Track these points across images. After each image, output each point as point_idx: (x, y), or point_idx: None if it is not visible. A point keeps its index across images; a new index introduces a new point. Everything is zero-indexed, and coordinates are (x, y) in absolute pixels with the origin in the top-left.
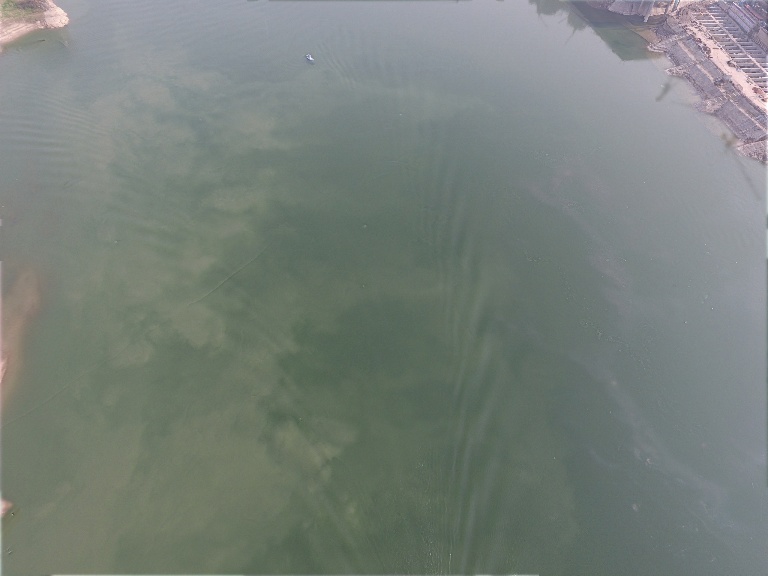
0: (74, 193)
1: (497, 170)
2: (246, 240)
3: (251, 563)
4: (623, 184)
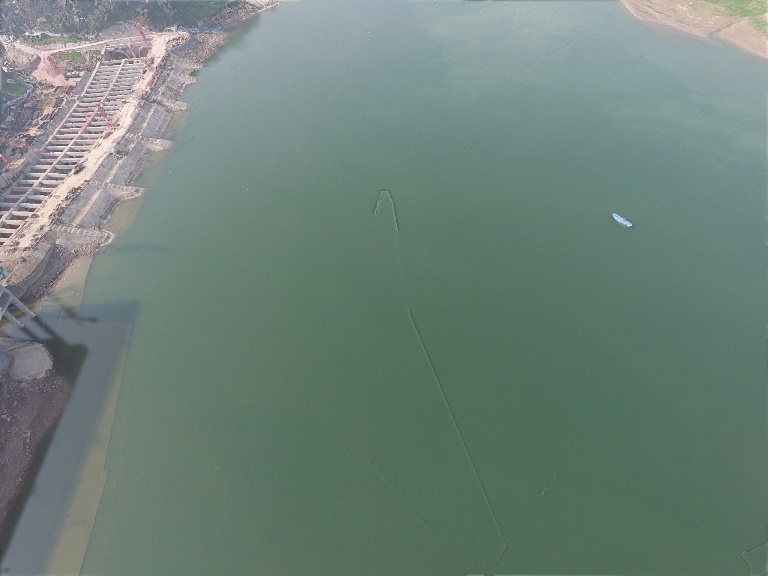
0: (718, 79)
1: (391, 84)
2: (561, 58)
3: None
4: (301, 85)
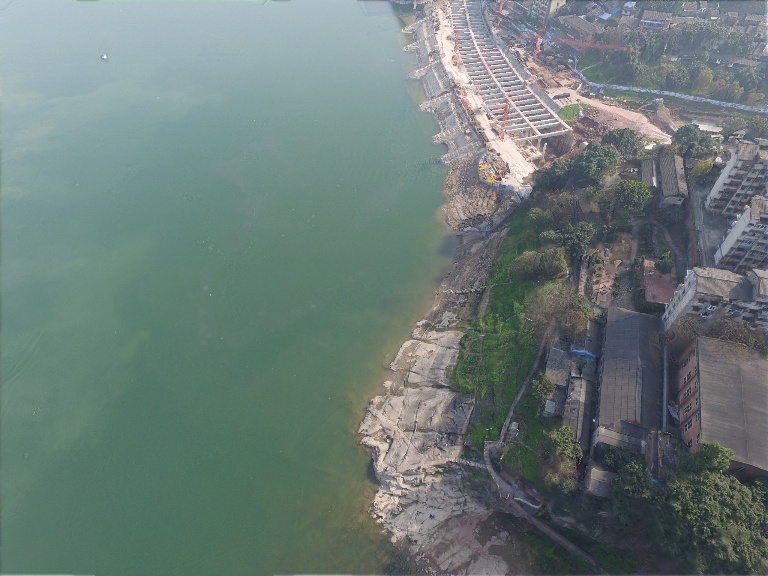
0: None
1: (202, 134)
2: None
3: None
4: (305, 139)
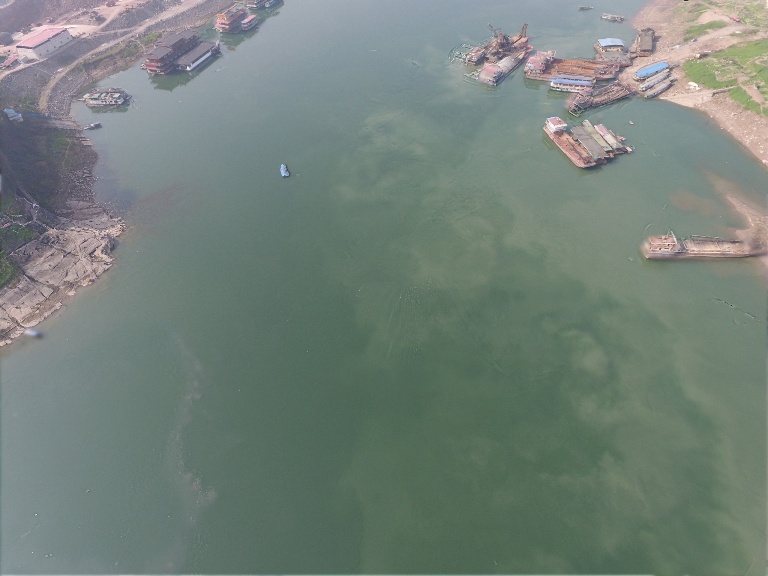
0: None
1: None
2: None
3: (534, 291)
4: None
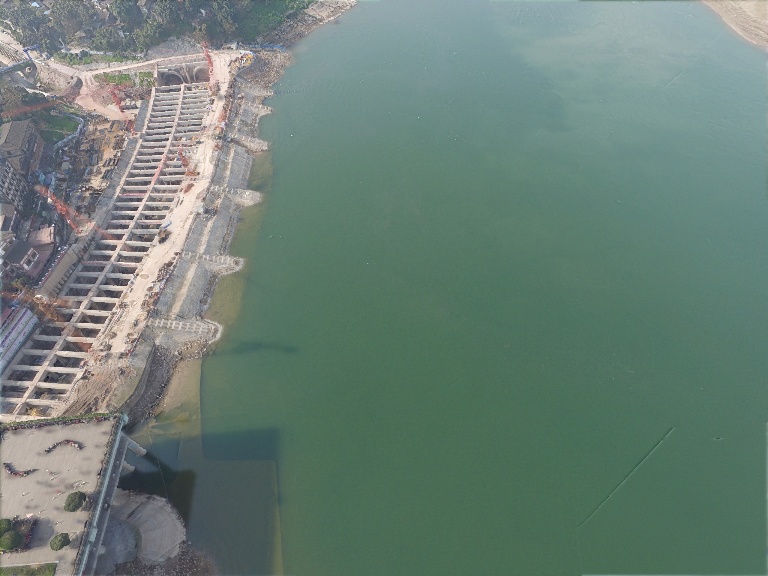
0: None
1: (505, 121)
2: (682, 89)
3: None
4: (395, 119)
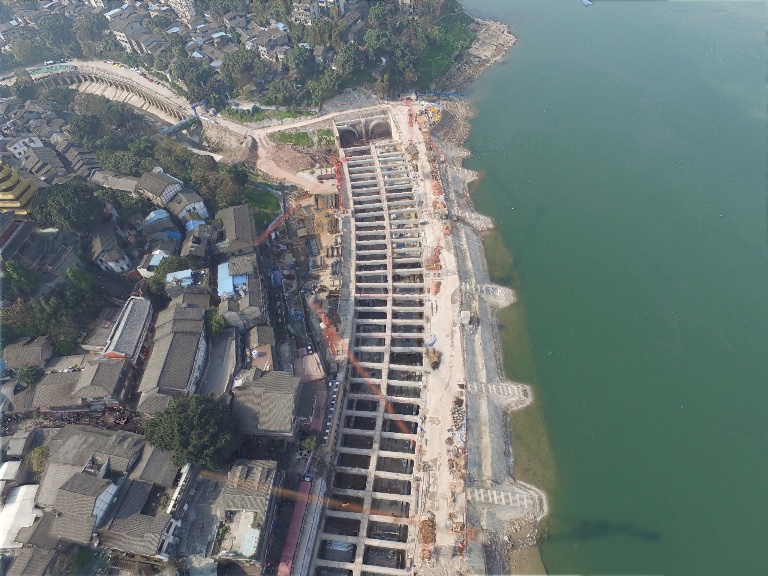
0: None
1: None
2: None
3: None
4: (631, 187)
